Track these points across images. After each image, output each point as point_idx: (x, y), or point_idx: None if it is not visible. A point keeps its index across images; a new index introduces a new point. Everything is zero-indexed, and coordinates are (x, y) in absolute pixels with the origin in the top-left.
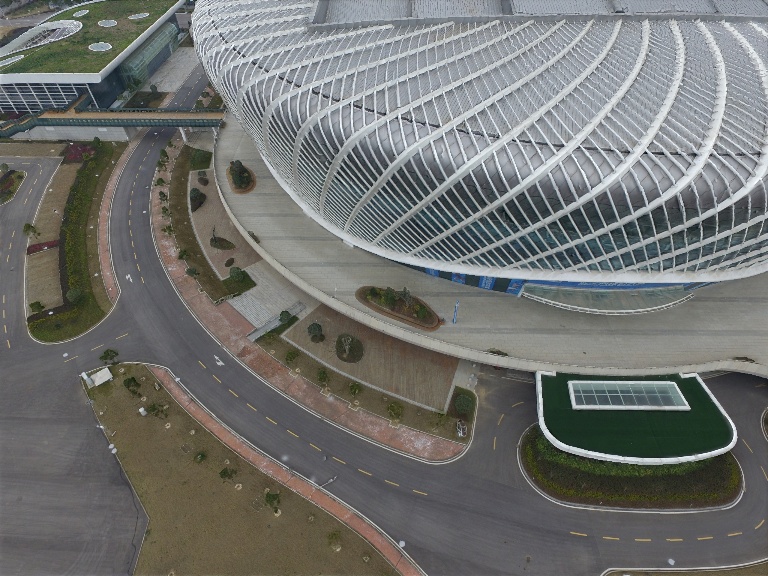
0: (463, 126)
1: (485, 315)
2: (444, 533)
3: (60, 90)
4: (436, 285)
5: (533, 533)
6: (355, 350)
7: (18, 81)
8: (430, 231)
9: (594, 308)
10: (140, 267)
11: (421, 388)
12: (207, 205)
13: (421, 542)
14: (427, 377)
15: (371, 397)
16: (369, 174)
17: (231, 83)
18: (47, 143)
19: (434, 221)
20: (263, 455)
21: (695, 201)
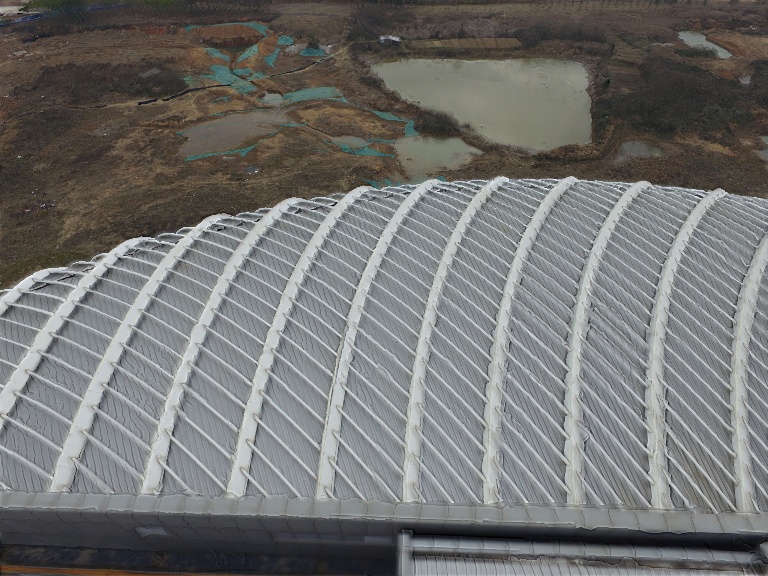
0: None
1: None
2: None
3: None
4: None
5: None
6: None
7: None
8: None
9: None
10: None
11: None
12: None
13: None
14: None
15: None
16: None
17: None
18: None
19: None
20: None
21: None
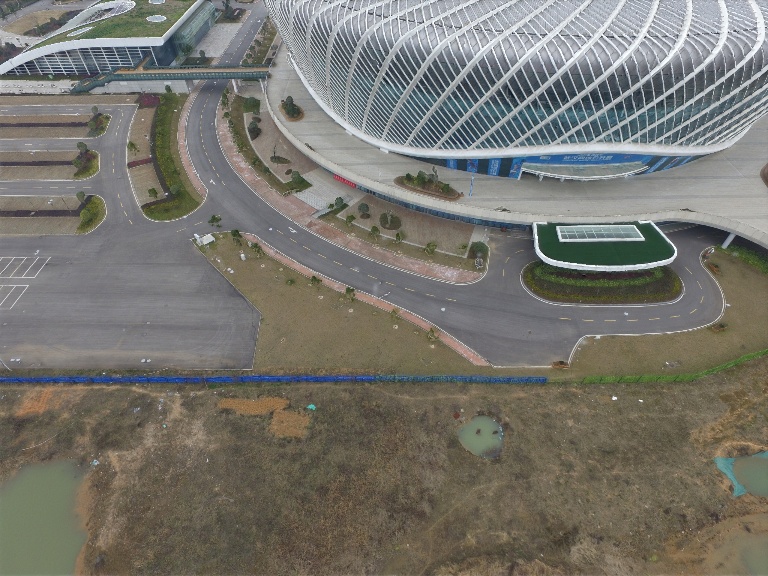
0: (478, 27)
1: (493, 191)
2: (470, 320)
3: (128, 53)
4: (455, 174)
5: (533, 319)
6: (395, 222)
7: (93, 45)
8: (453, 117)
9: (574, 175)
10: (219, 175)
11: (447, 243)
12: (263, 136)
13: (454, 325)
14: (451, 237)
15: (410, 249)
16: (410, 69)
17: (303, 14)
18: (122, 95)
19: (457, 105)
20: (335, 282)
21: (635, 68)
